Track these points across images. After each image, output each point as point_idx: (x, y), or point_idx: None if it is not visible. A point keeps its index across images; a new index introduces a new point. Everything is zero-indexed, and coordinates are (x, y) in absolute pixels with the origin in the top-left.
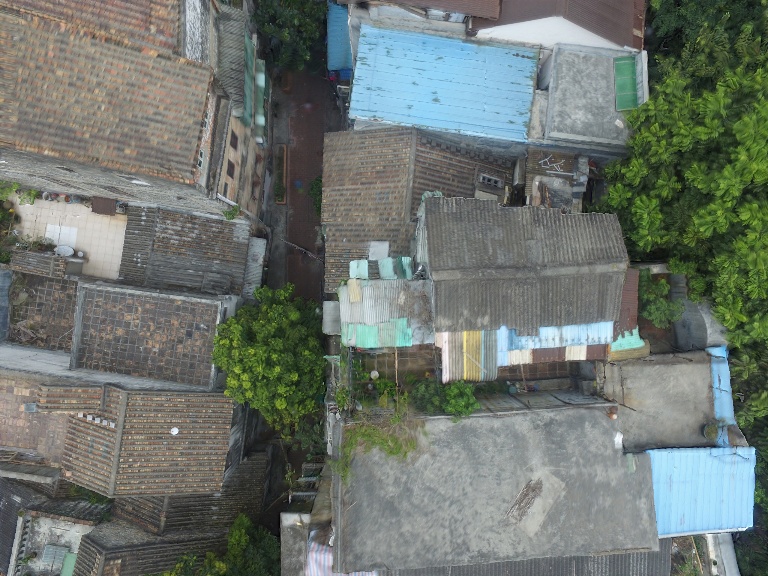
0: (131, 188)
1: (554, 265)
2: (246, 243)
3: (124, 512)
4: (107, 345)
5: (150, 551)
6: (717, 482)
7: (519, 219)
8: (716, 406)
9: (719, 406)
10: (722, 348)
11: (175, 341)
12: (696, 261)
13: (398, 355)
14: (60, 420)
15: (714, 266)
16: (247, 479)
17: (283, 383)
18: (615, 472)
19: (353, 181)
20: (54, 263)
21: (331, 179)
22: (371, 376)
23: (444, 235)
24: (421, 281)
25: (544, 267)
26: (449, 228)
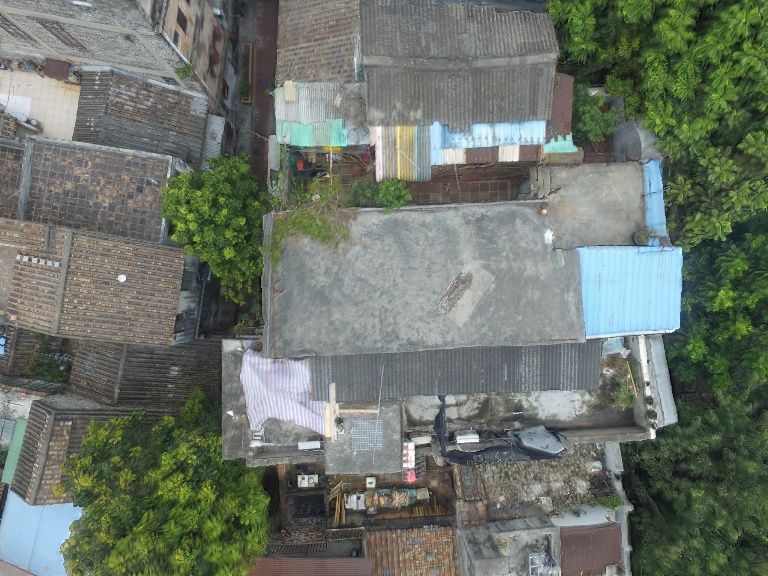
0: (76, 22)
1: (486, 57)
2: (204, 118)
3: (79, 388)
4: (56, 199)
5: (102, 417)
6: (645, 282)
7: (453, 15)
8: (648, 217)
9: (651, 217)
10: (655, 161)
11: (125, 196)
12: (632, 77)
13: (341, 181)
14: (6, 268)
15: (646, 71)
16: (205, 360)
17: (231, 228)
18: (544, 267)
19: (307, 39)
20: (4, 121)
21: (286, 40)
22: (313, 199)
23: (377, 25)
24: (357, 84)
25: (476, 58)
26: (382, 20)
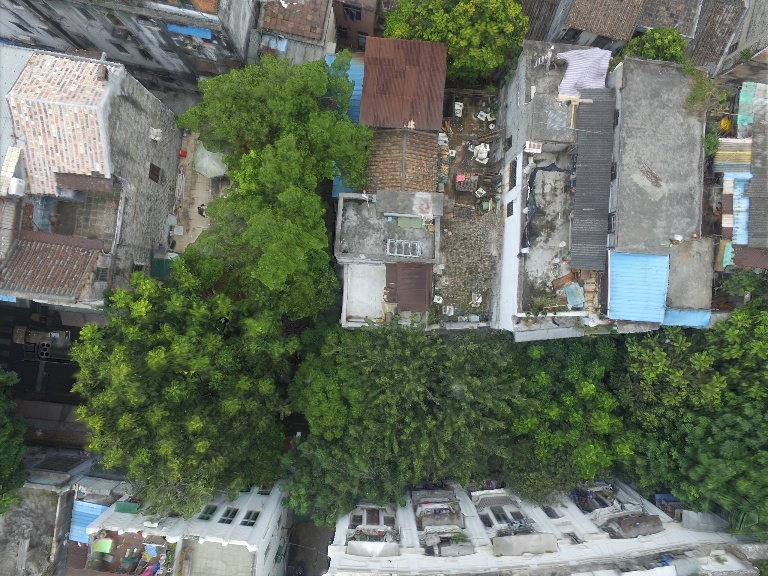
0: None
1: None
2: None
3: None
4: None
5: None
6: (643, 297)
7: None
8: (675, 311)
9: (675, 313)
10: (708, 321)
11: (668, 6)
12: None
13: None
14: None
15: None
16: None
17: None
18: (661, 232)
19: None
20: None
21: None
22: None
23: None
24: None
25: None
26: None
